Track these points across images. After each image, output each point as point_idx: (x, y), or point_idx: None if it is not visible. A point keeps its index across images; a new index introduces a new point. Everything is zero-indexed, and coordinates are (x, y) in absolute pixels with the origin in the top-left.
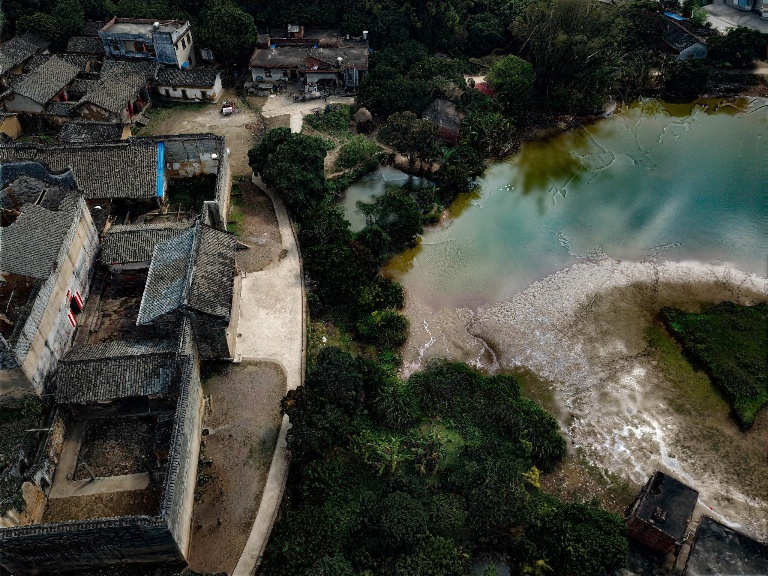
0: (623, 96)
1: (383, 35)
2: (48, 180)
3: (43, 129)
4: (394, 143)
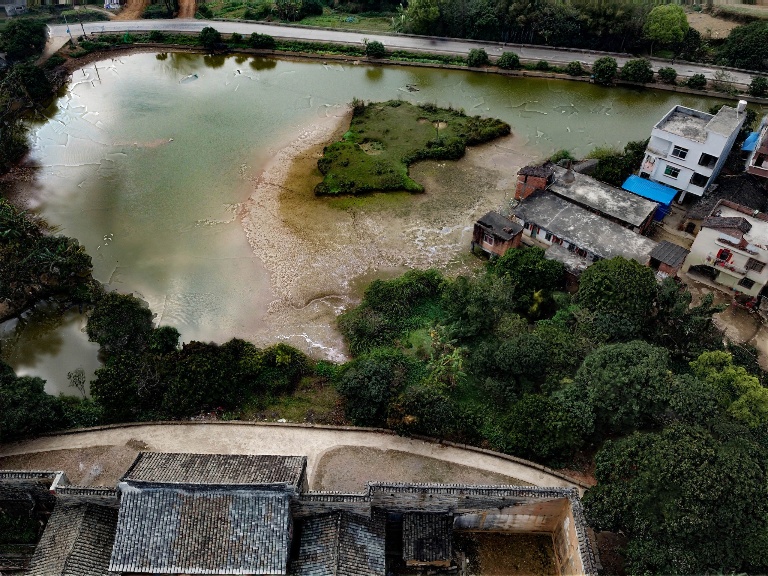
0: (49, 115)
1: None
2: None
3: None
4: None
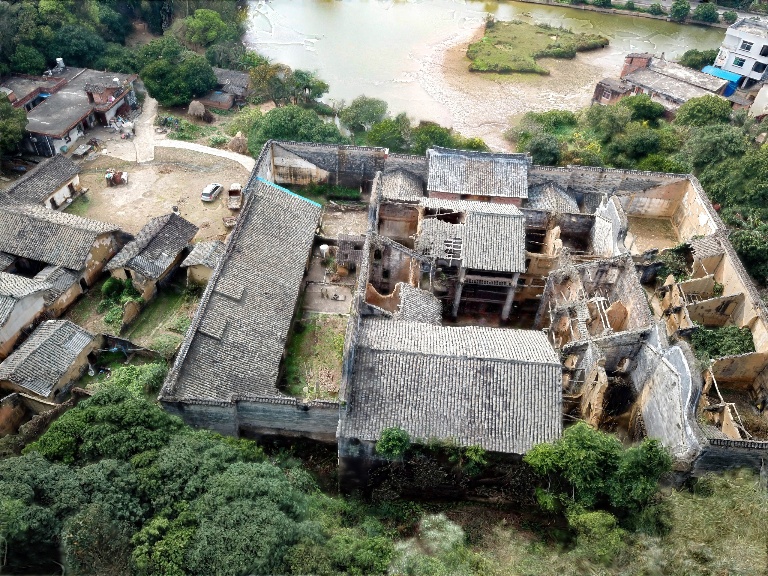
0: (270, 4)
1: (87, 50)
2: None
3: None
4: None
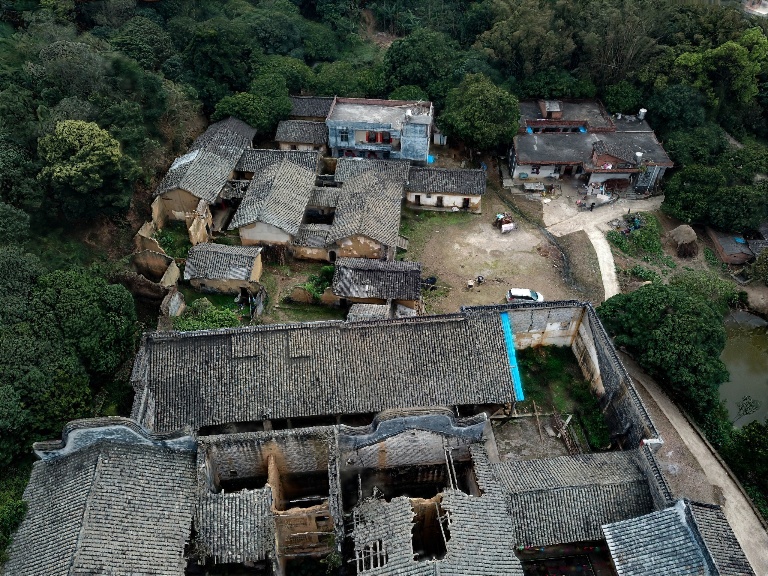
0: None
1: (674, 117)
2: (445, 432)
3: (286, 263)
4: (735, 274)
